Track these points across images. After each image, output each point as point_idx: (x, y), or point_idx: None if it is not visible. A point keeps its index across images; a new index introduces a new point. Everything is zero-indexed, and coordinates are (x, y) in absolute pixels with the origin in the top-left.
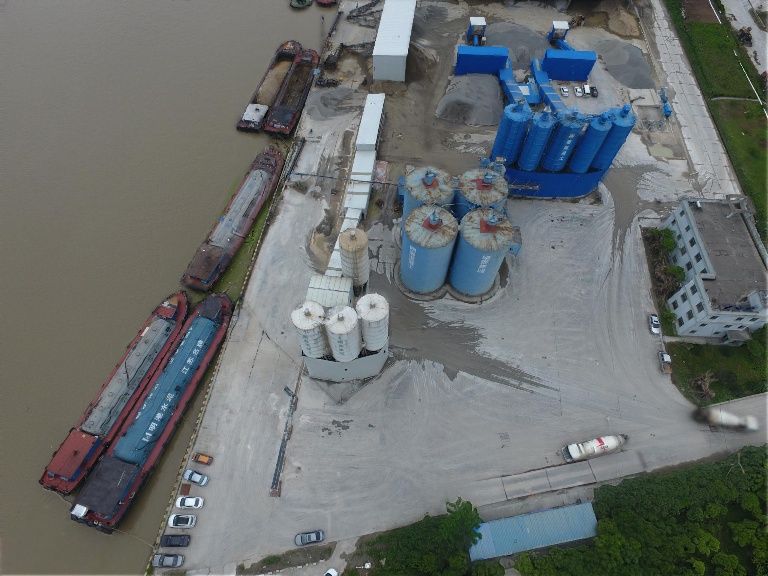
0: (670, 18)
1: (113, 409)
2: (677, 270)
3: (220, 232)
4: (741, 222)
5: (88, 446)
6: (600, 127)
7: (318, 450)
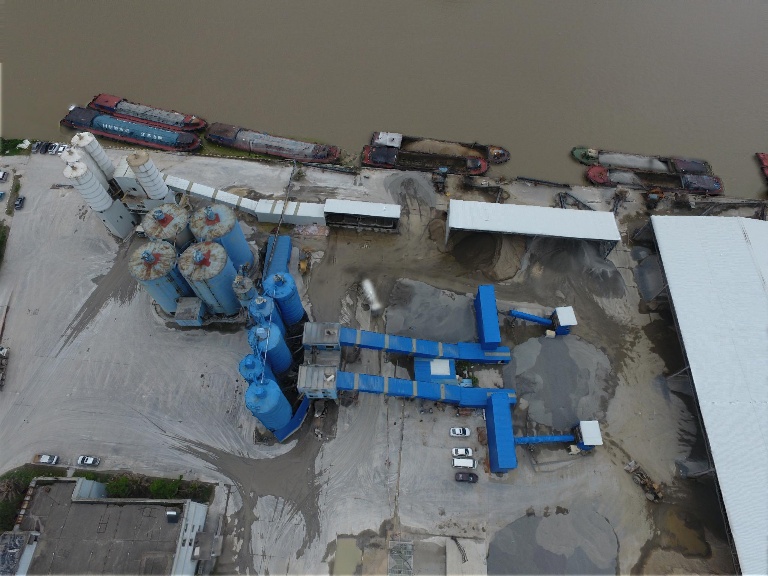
0: None
1: (129, 110)
2: (119, 483)
3: (250, 134)
4: (142, 575)
5: (109, 105)
6: None
7: (71, 204)
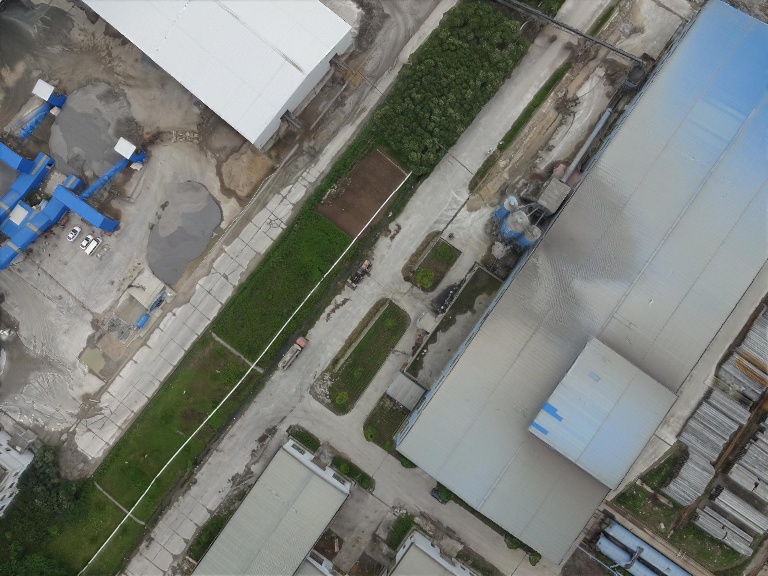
0: (314, 190)
1: None
2: None
3: None
4: None
5: None
6: None
7: None
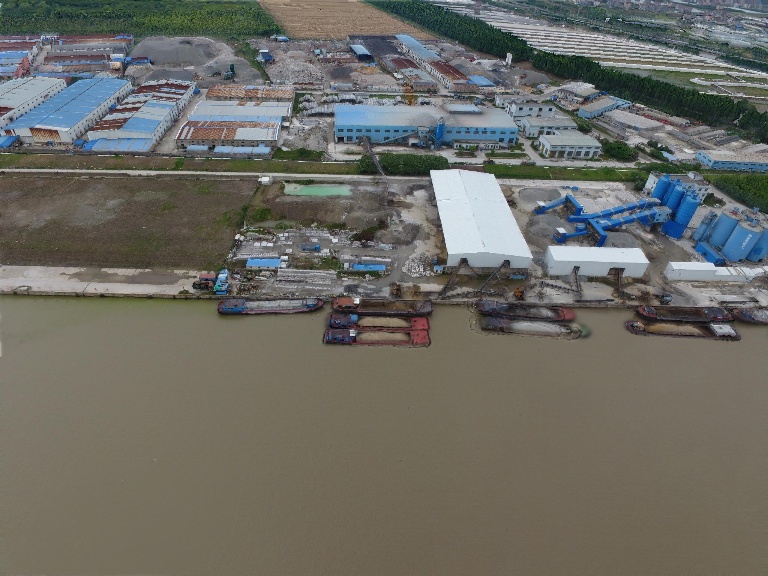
0: None
1: None
2: None
3: None
4: None
5: None
6: (680, 183)
7: None
